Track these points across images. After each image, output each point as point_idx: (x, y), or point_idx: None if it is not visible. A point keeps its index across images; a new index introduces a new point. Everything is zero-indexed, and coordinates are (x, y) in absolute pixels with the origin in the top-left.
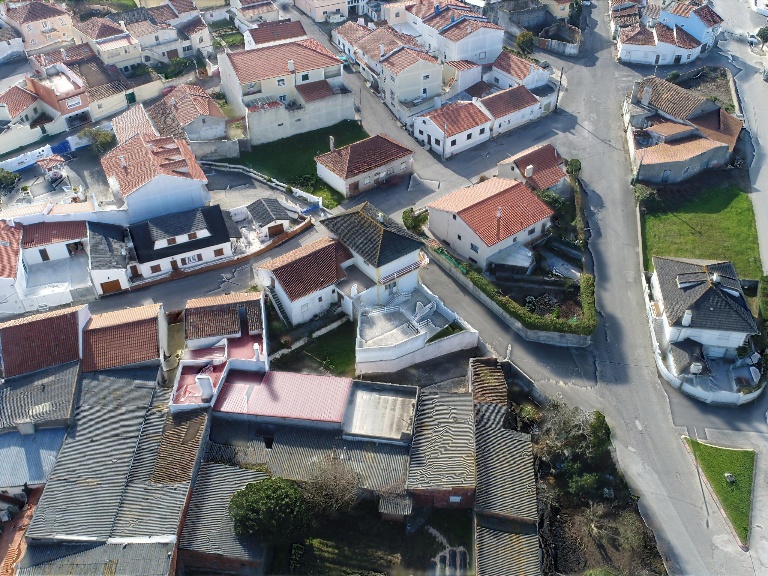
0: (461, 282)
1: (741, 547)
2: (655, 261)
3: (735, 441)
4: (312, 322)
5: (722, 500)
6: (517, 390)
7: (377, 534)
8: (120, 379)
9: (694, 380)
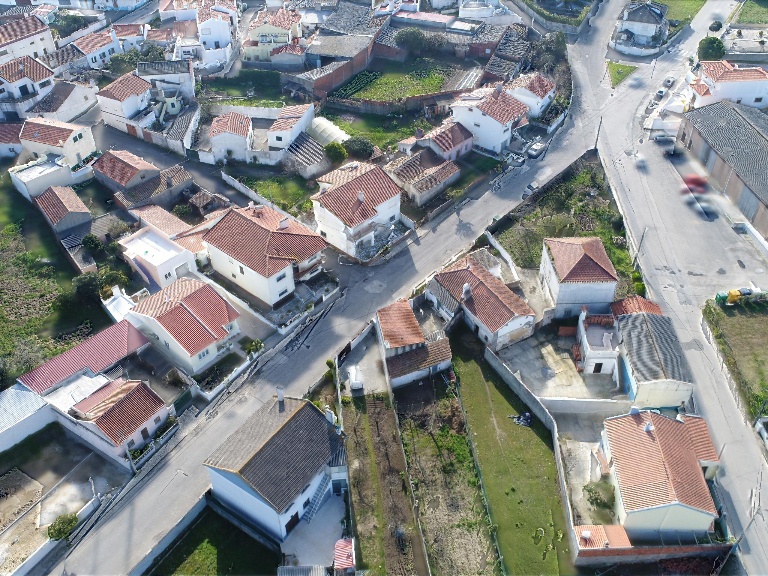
0: (522, 7)
1: (612, 87)
2: (626, 3)
3: (631, 64)
4: (442, 9)
5: (612, 76)
6: (533, 39)
7: (453, 60)
8: (355, 4)
9: (622, 43)
